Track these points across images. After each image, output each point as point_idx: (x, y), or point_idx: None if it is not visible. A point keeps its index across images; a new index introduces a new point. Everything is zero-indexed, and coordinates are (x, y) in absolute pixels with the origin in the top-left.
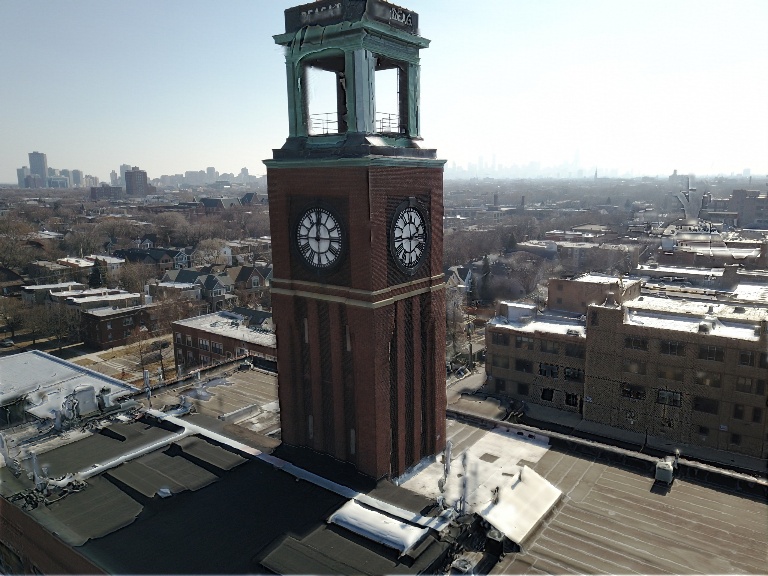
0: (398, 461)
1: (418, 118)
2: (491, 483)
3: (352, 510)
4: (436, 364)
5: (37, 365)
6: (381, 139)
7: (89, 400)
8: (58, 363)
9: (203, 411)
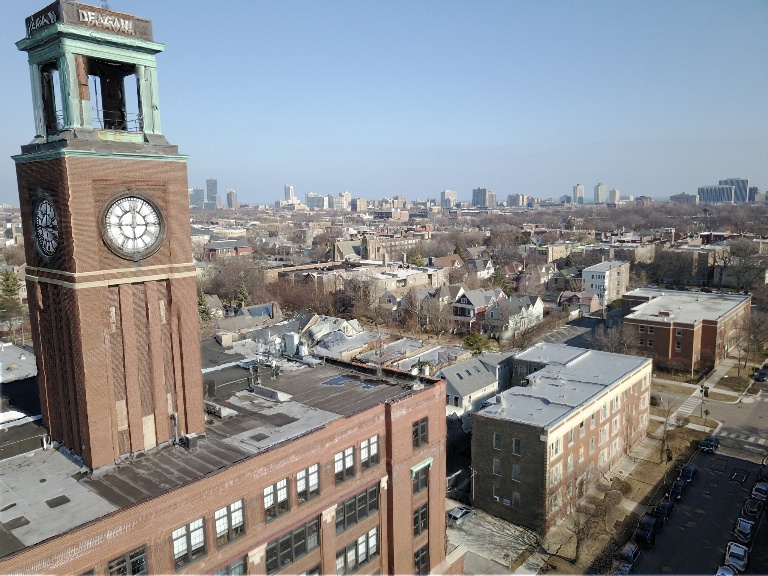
0: (63, 431)
1: (70, 108)
2: (8, 495)
3: (6, 412)
4: (75, 366)
5: (621, 366)
6: (42, 139)
7: (291, 344)
8: (630, 370)
9: (296, 384)
